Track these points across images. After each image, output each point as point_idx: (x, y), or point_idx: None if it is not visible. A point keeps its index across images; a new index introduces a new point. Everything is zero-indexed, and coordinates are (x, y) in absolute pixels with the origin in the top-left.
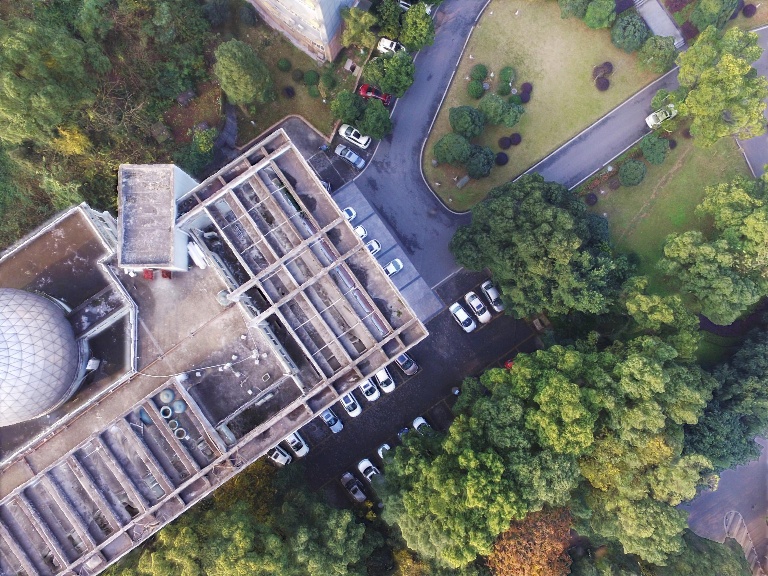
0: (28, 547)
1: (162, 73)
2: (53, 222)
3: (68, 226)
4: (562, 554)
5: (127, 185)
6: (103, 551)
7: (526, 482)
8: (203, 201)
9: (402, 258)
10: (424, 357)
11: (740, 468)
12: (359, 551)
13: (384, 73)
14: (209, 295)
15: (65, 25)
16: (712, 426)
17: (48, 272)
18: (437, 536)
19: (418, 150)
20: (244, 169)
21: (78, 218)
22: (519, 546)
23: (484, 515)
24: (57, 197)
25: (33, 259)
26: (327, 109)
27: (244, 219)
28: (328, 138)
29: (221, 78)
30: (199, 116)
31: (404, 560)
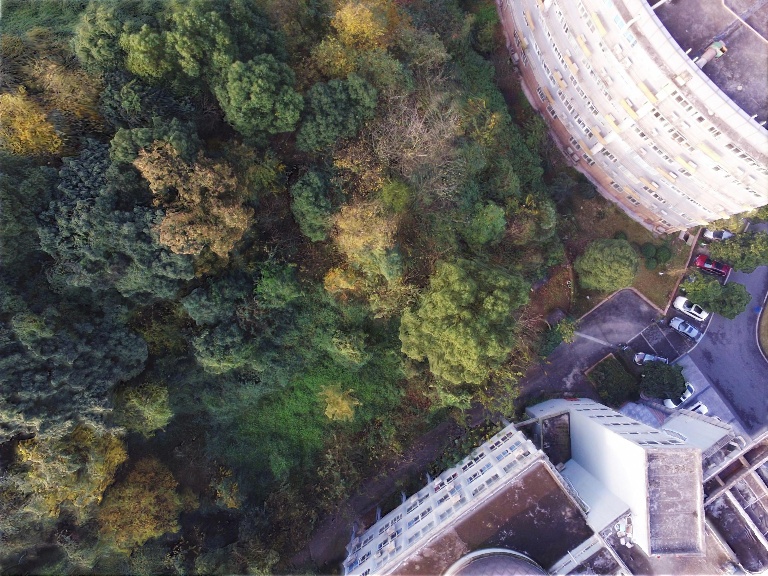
0: None
1: (523, 264)
2: (512, 472)
3: (528, 477)
4: None
5: (650, 469)
6: None
7: None
8: (729, 485)
9: (740, 433)
10: None
11: None
12: None
13: (743, 255)
14: (709, 566)
15: (454, 233)
16: None
17: (510, 525)
18: None
19: (753, 320)
20: (763, 446)
21: (538, 468)
22: None
23: None
24: (442, 405)
25: (494, 511)
26: (662, 281)
27: (765, 499)
28: (663, 310)
29: (589, 271)
30: (549, 300)
31: None
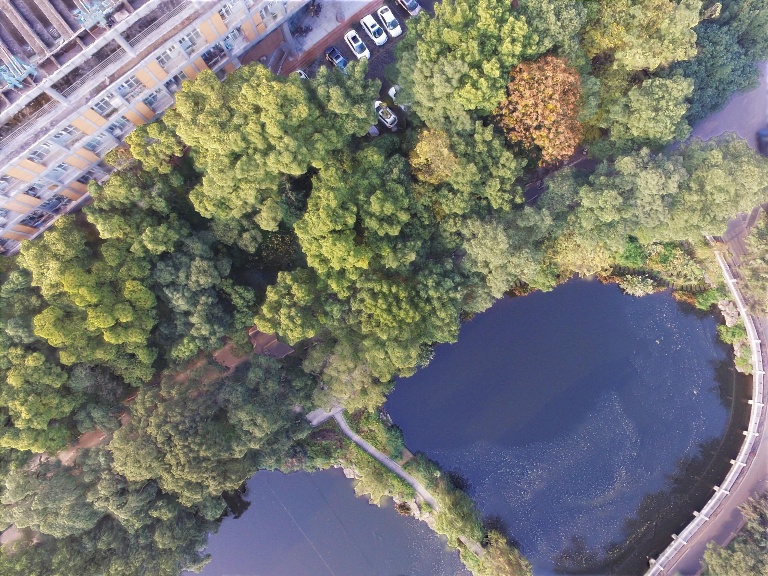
0: (56, 4)
1: None
2: None
3: None
4: (573, 121)
5: None
6: (130, 2)
7: (535, 13)
8: None
9: None
10: (428, 4)
11: (741, 125)
12: (376, 144)
13: None
14: None
15: None
16: (711, 38)
17: None
18: (452, 64)
19: None
20: None
21: None
22: (531, 81)
23: (496, 53)
24: None
25: None
26: None
27: None
28: None
29: None
30: None
31: (420, 133)
